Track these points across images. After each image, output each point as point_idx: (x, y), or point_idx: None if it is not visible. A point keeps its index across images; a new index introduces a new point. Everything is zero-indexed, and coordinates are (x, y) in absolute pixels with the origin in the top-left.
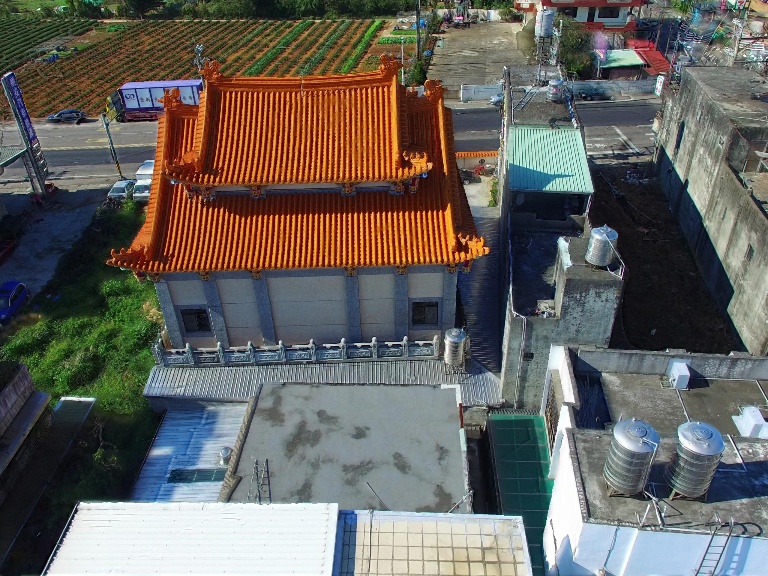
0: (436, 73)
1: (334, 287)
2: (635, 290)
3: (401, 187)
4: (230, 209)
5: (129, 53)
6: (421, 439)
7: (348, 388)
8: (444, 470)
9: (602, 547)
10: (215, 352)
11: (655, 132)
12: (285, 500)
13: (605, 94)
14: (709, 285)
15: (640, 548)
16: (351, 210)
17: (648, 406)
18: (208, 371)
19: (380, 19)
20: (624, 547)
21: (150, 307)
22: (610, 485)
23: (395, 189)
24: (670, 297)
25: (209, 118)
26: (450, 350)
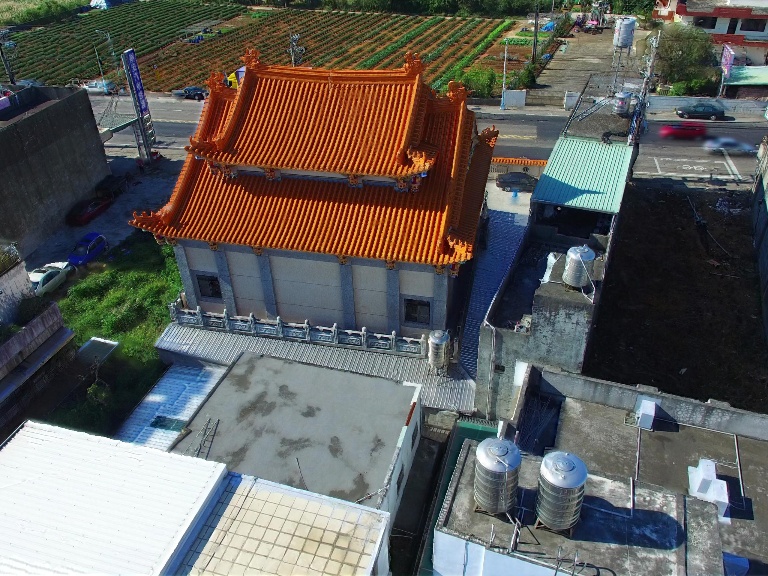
0: (548, 78)
1: (330, 273)
2: (679, 324)
3: (402, 184)
4: (247, 188)
5: (264, 39)
6: (363, 428)
7: (317, 369)
8: (372, 461)
9: (457, 559)
10: (221, 318)
11: (759, 159)
12: (219, 458)
13: (705, 113)
14: (767, 331)
15: (491, 568)
16: (354, 201)
17: (600, 439)
18: (214, 334)
19: (511, 19)
20: (477, 564)
21: None
22: (475, 500)
23: (397, 185)
24: (717, 337)
25: (242, 102)
26: (432, 351)
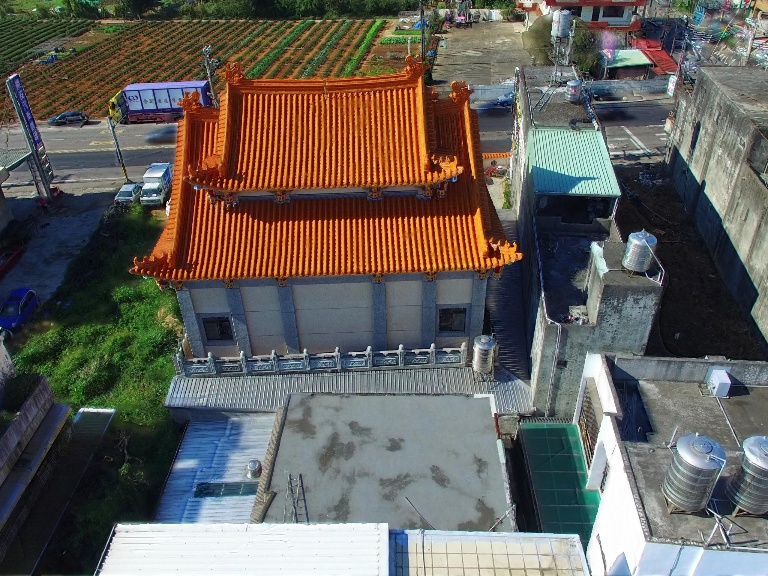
0: (441, 73)
1: (360, 294)
2: None
3: (429, 191)
4: (254, 215)
5: (129, 54)
6: (458, 451)
7: (379, 398)
8: (484, 483)
9: (664, 566)
10: (238, 361)
11: (667, 132)
12: (322, 516)
13: (617, 94)
14: (730, 287)
15: (704, 567)
16: (378, 215)
17: (689, 415)
18: (230, 381)
19: (381, 19)
20: (687, 566)
21: (164, 314)
22: (671, 502)
23: (423, 193)
24: (691, 300)
25: (231, 121)
26: (479, 357)
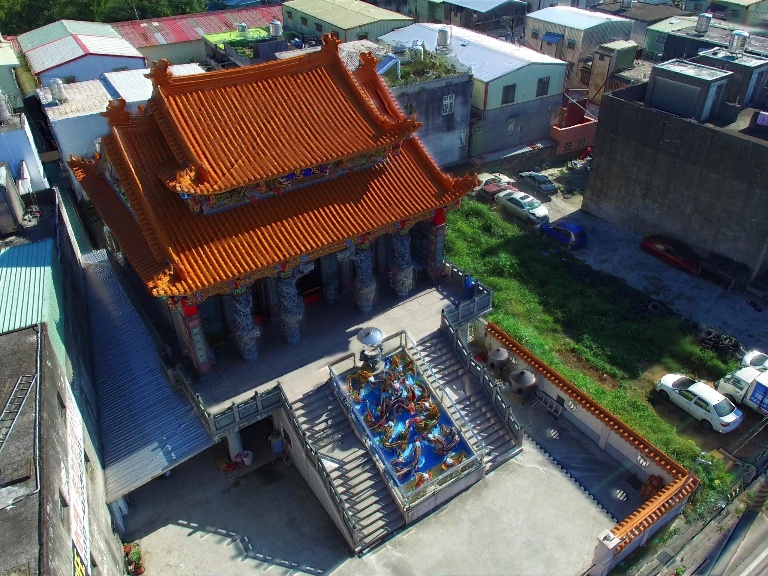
0: None
1: None
2: None
3: None
4: None
5: None
6: None
7: None
8: None
9: None
10: None
11: None
12: None
13: None
14: None
15: None
16: None
17: None
18: None
19: None
20: None
21: None
22: None
23: None
24: None
25: None
26: None
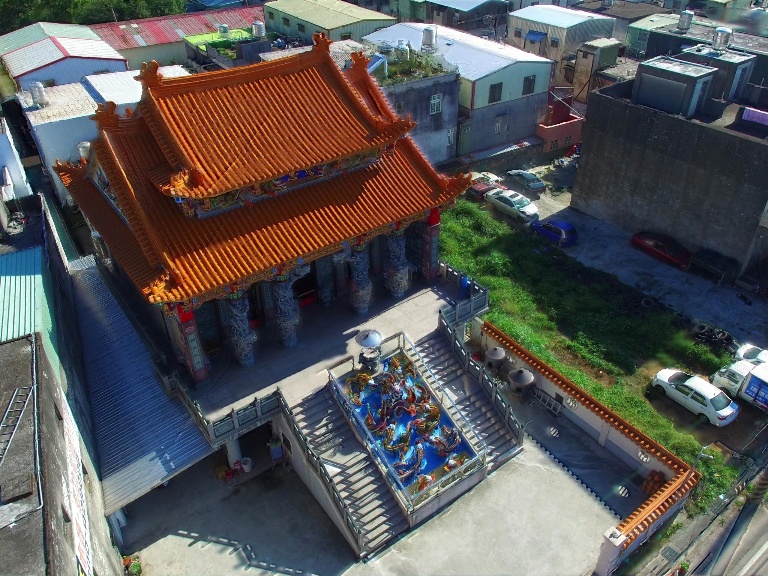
0: None
1: None
2: None
3: None
4: None
5: None
6: None
7: None
8: None
9: None
10: None
11: None
12: None
13: None
14: None
15: None
16: None
17: None
18: None
19: None
20: None
21: None
22: None
23: None
24: None
25: None
26: None
